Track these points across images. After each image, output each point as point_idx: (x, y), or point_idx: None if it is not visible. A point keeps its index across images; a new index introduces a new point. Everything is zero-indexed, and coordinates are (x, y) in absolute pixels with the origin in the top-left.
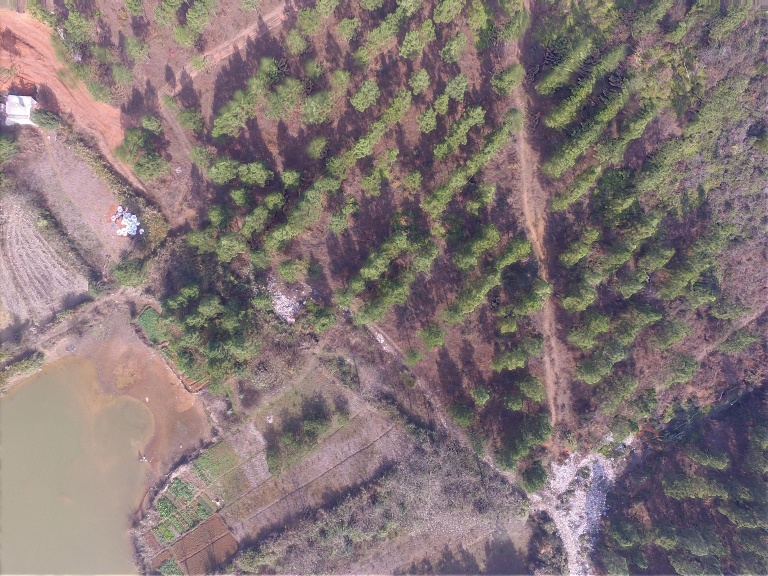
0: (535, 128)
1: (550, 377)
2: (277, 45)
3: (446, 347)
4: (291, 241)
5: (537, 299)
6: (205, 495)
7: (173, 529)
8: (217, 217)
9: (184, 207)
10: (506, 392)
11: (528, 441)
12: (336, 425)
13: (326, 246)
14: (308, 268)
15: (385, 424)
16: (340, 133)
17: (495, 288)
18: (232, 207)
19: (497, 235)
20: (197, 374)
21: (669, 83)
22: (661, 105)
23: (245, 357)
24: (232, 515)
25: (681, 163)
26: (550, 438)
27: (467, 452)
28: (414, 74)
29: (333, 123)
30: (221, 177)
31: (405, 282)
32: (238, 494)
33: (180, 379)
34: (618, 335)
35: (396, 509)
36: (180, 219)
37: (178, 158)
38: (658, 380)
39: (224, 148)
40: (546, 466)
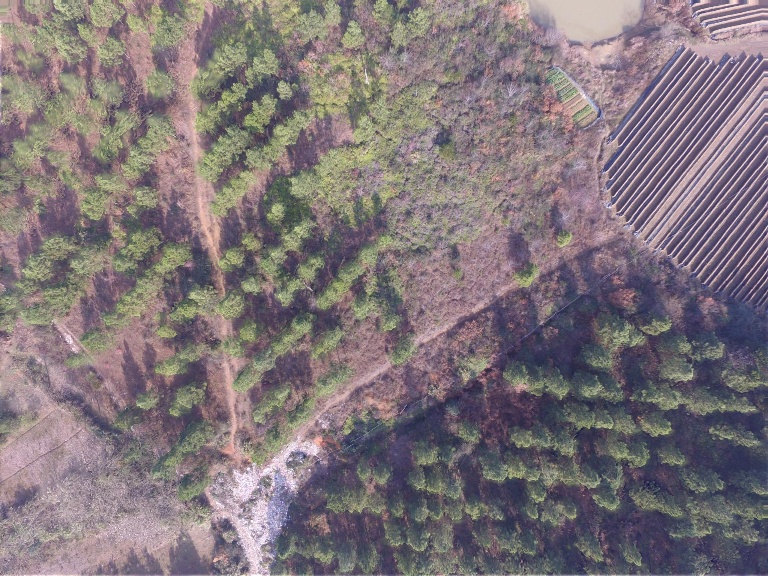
0: (206, 133)
1: (230, 384)
2: None
3: (130, 350)
4: None
5: (187, 304)
6: None
7: None
8: None
9: None
10: (175, 397)
11: None
12: (28, 424)
13: (17, 246)
14: (0, 267)
15: (75, 425)
16: (28, 134)
17: (173, 292)
18: None
19: (156, 239)
20: None
21: (347, 89)
22: (335, 111)
23: None
24: None
25: (354, 170)
26: (232, 445)
27: (152, 456)
28: (93, 77)
29: (20, 124)
30: None
31: (74, 284)
32: None
33: None
34: (271, 343)
35: None
36: None
37: None
38: (337, 391)
39: None
40: (226, 474)
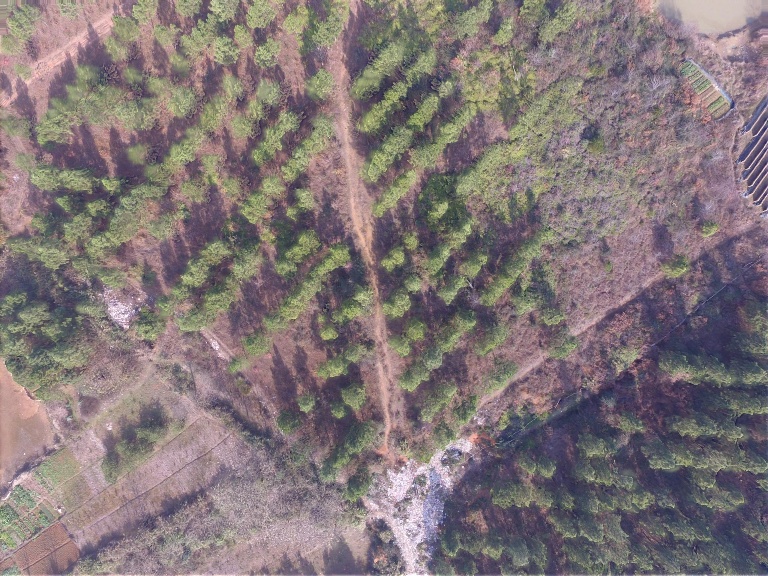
0: (359, 133)
1: (384, 384)
2: (106, 52)
3: (280, 354)
4: (123, 248)
5: (353, 305)
6: (47, 502)
7: (15, 536)
8: (40, 224)
9: (22, 214)
10: (333, 399)
11: (347, 449)
12: (174, 432)
13: (160, 252)
14: (142, 275)
15: (222, 431)
16: (170, 139)
17: (325, 294)
18: (65, 214)
19: (316, 241)
20: (27, 381)
21: (497, 86)
22: (487, 108)
23: (73, 364)
24: (73, 523)
25: (508, 167)
26: (386, 445)
27: (304, 459)
28: (239, 79)
29: (162, 129)
30: (46, 184)
31: (229, 289)
32: (79, 501)
33: (23, 386)
34: (437, 342)
35: (234, 517)
36: (19, 226)
37: (15, 165)
38: None
39: (59, 155)
40: (381, 474)
